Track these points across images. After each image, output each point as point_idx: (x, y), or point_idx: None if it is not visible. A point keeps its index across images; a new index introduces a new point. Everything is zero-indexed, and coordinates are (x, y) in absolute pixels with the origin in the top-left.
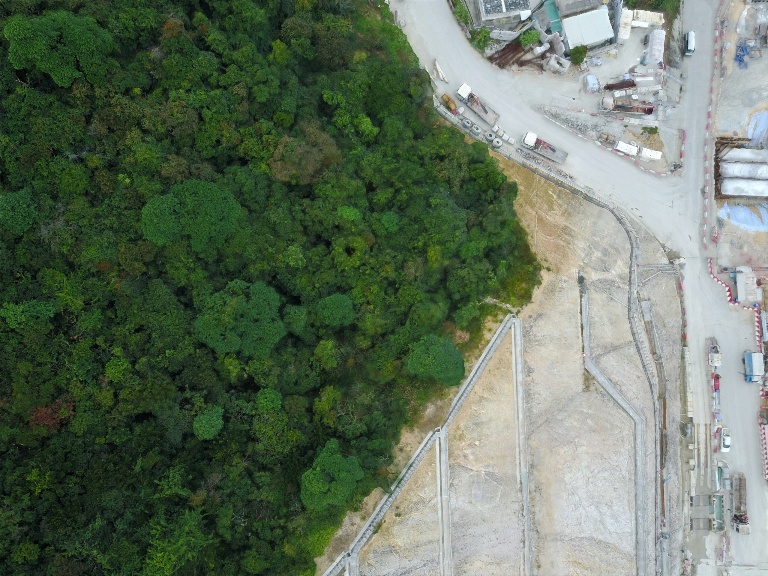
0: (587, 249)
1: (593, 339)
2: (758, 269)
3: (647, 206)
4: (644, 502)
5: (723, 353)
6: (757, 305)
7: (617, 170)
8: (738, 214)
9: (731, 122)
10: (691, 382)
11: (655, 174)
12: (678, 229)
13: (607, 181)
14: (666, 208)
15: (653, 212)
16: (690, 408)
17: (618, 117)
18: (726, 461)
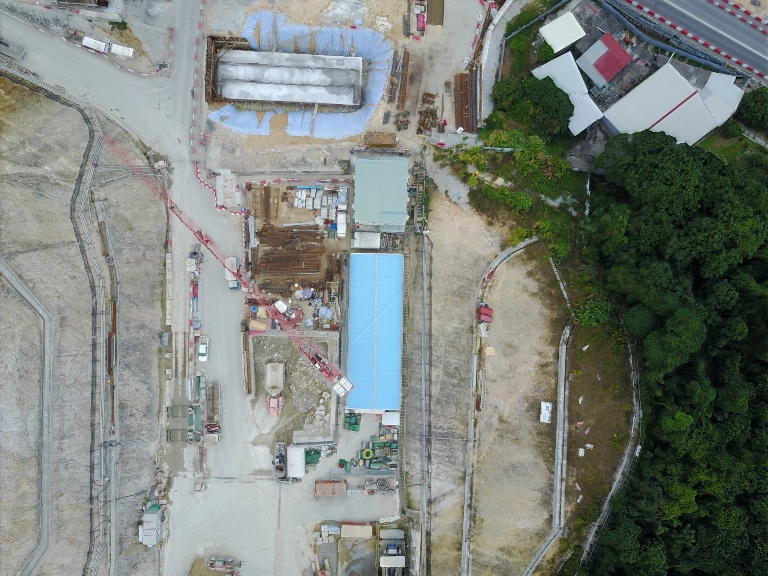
0: (17, 143)
1: (5, 234)
2: (251, 174)
3: (129, 107)
4: (50, 402)
5: (210, 260)
6: (243, 210)
7: (91, 68)
8: (239, 118)
9: (226, 21)
10: (171, 289)
11: (136, 73)
12: (166, 132)
13: (80, 80)
14: (152, 110)
15: (137, 114)
16: (168, 316)
17: (73, 10)
18: (204, 370)
